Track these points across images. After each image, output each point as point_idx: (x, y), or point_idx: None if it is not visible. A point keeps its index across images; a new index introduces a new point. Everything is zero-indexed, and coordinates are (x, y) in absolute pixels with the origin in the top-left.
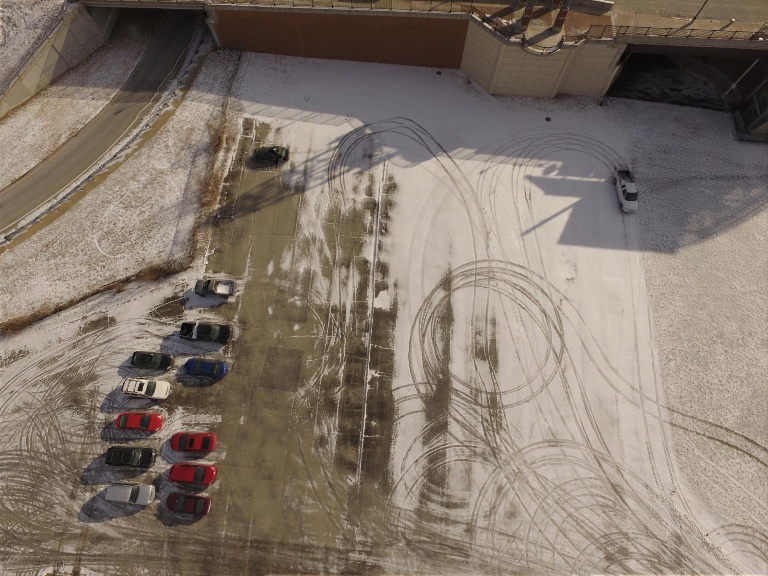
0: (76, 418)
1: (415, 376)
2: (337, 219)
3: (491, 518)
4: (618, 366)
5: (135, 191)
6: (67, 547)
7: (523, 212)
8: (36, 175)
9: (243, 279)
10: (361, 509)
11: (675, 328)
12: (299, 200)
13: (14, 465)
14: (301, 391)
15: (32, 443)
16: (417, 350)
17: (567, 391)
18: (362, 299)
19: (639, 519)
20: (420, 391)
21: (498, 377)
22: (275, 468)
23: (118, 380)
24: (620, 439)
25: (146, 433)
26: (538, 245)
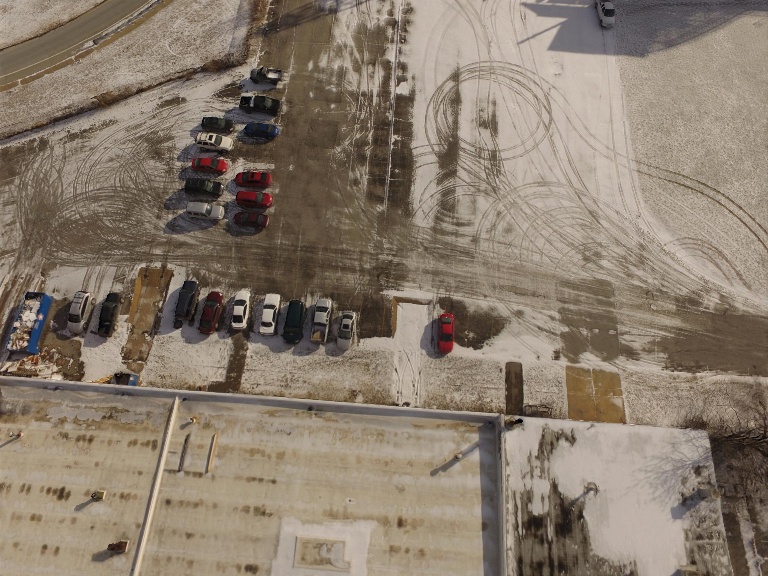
0: (158, 165)
1: (430, 139)
2: (364, 32)
3: (492, 233)
4: (596, 133)
5: (197, 10)
6: (156, 250)
7: (519, 28)
8: (114, 1)
9: (288, 73)
10: (388, 227)
11: (644, 108)
12: (333, 18)
13: (111, 197)
14: (338, 148)
15: (124, 182)
16: (432, 122)
17: (554, 149)
18: (386, 87)
19: (611, 234)
20: (434, 149)
21: (498, 140)
22: (318, 199)
23: (190, 140)
24: (596, 181)
25: (215, 175)
26: (531, 50)
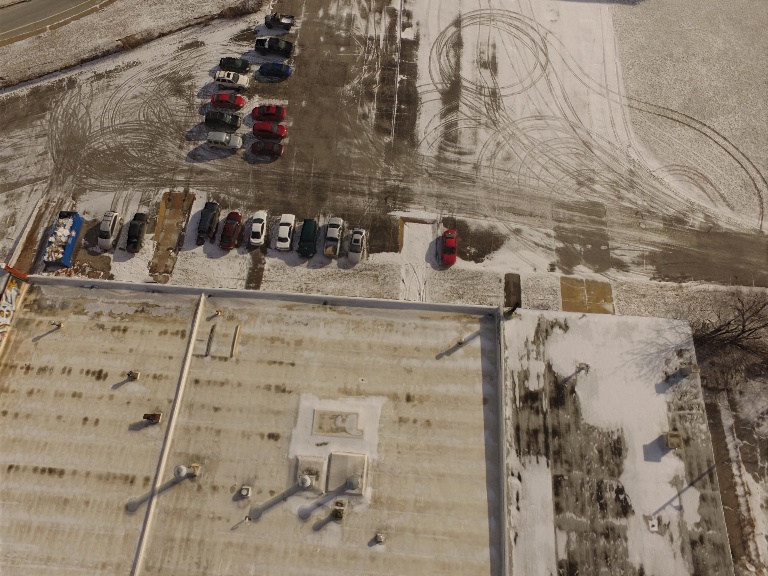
0: (179, 101)
1: (434, 79)
2: None
3: (492, 160)
4: (590, 73)
5: None
6: (178, 177)
7: None
8: None
9: (300, 19)
10: (395, 156)
11: (635, 50)
12: None
13: (135, 129)
14: (347, 87)
15: (148, 116)
16: (435, 63)
17: (550, 87)
18: (392, 32)
19: (603, 161)
20: (438, 87)
21: (497, 79)
22: (330, 132)
23: (209, 79)
24: (590, 115)
25: (232, 110)
26: None
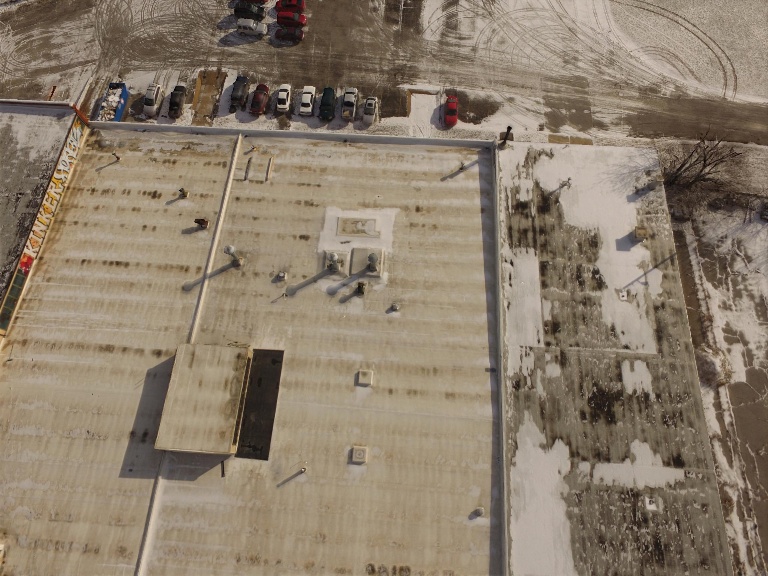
0: None
1: None
2: None
3: (488, 44)
4: None
5: None
6: (212, 59)
7: None
8: None
9: None
10: (402, 41)
11: None
12: None
13: (172, 21)
14: None
15: (183, 10)
16: None
17: None
18: None
19: (586, 44)
20: None
21: None
22: (344, 22)
23: None
24: (575, 7)
25: (258, 5)
26: None
